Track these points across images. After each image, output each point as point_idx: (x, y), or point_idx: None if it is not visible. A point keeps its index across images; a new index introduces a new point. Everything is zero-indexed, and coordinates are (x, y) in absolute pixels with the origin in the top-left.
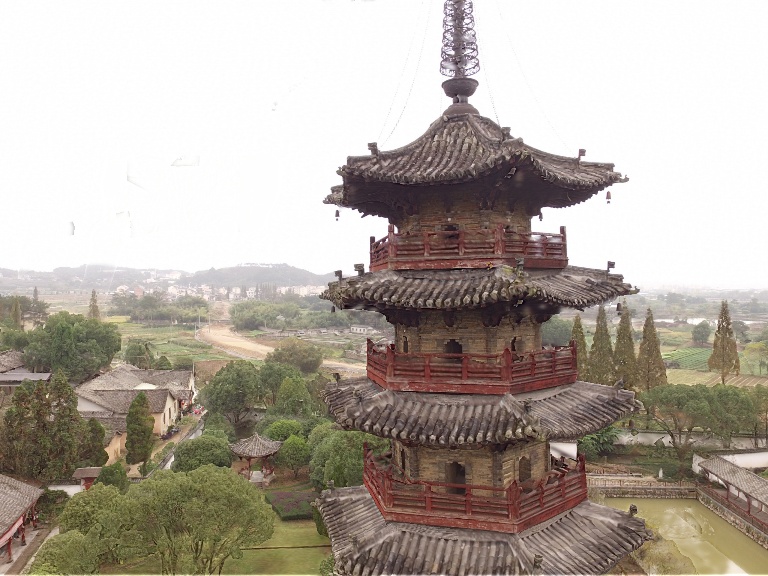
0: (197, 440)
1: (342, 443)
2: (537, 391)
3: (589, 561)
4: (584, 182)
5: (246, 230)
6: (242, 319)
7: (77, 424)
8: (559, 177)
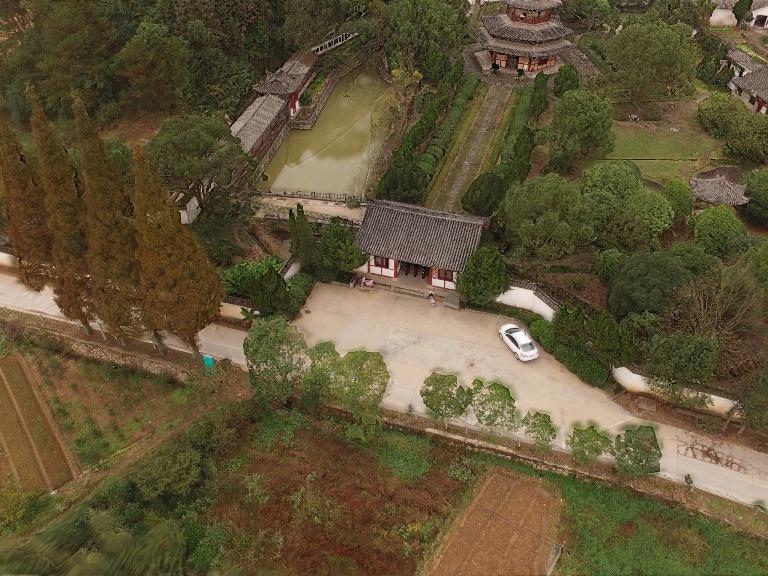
0: None
1: None
2: None
3: None
4: None
5: None
6: None
7: None
8: None
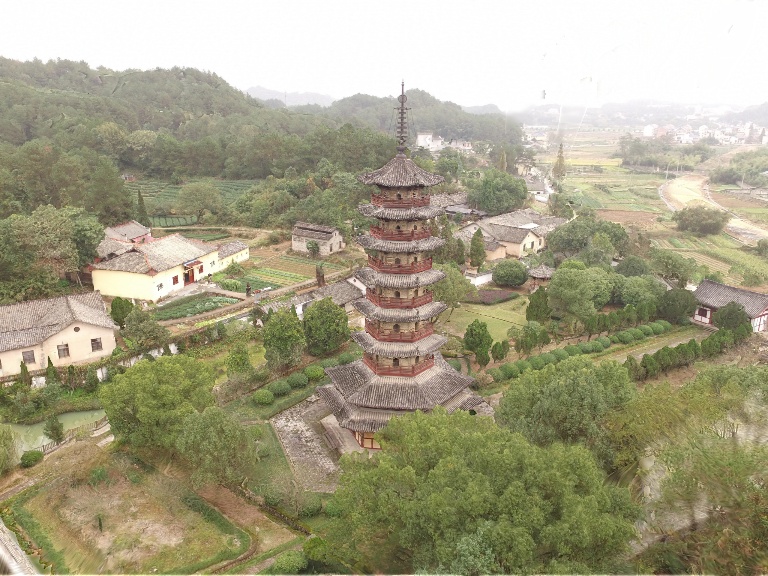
0: (508, 261)
1: (555, 275)
2: (395, 240)
3: (397, 284)
4: (405, 185)
5: (705, 86)
6: (718, 172)
7: (449, 240)
8: (393, 185)
